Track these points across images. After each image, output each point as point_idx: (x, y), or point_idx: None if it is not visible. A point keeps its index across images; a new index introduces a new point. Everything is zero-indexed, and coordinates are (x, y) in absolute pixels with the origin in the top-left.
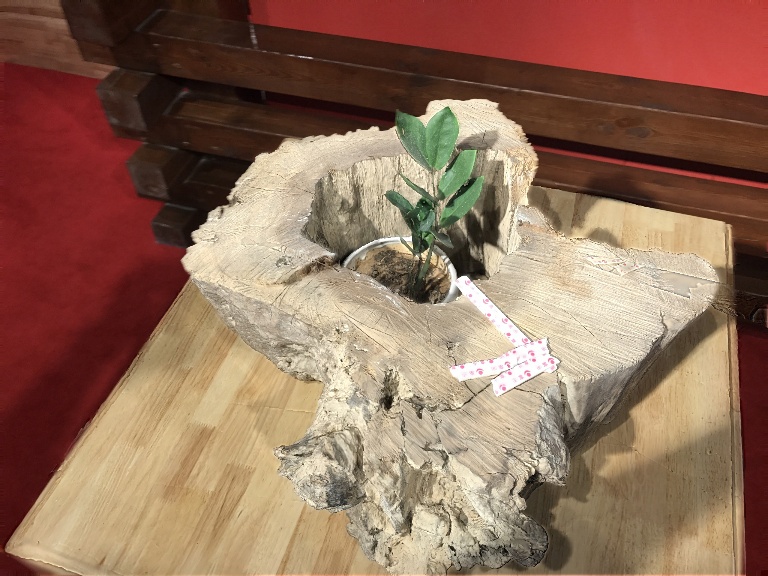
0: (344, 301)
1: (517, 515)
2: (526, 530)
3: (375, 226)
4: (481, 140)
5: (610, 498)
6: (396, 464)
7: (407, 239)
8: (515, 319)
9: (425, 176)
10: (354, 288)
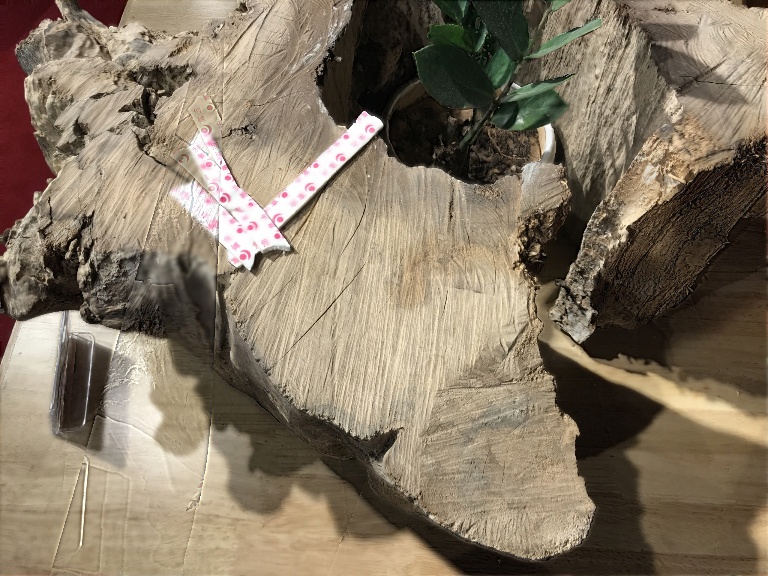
0: (294, 2)
1: (40, 267)
2: (21, 279)
3: (542, 75)
4: (693, 74)
5: (261, 501)
6: (51, 98)
7: (547, 127)
8: (321, 203)
9: (607, 56)
10: (321, 8)
